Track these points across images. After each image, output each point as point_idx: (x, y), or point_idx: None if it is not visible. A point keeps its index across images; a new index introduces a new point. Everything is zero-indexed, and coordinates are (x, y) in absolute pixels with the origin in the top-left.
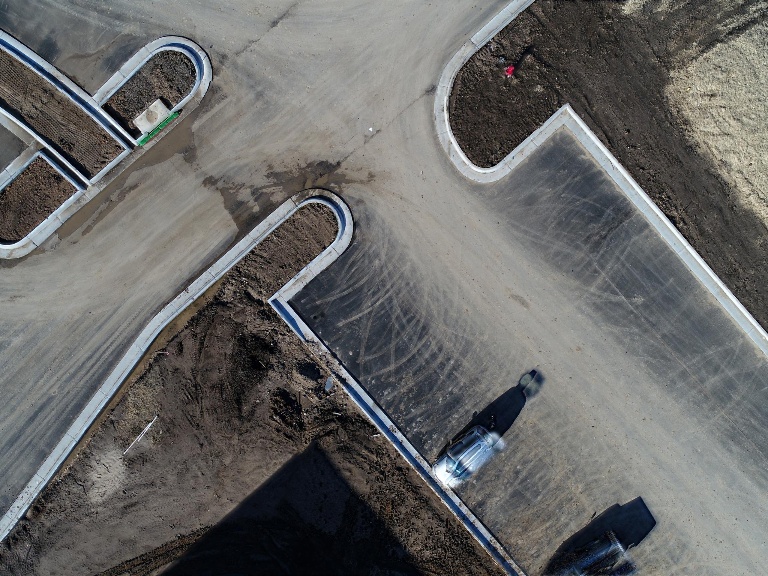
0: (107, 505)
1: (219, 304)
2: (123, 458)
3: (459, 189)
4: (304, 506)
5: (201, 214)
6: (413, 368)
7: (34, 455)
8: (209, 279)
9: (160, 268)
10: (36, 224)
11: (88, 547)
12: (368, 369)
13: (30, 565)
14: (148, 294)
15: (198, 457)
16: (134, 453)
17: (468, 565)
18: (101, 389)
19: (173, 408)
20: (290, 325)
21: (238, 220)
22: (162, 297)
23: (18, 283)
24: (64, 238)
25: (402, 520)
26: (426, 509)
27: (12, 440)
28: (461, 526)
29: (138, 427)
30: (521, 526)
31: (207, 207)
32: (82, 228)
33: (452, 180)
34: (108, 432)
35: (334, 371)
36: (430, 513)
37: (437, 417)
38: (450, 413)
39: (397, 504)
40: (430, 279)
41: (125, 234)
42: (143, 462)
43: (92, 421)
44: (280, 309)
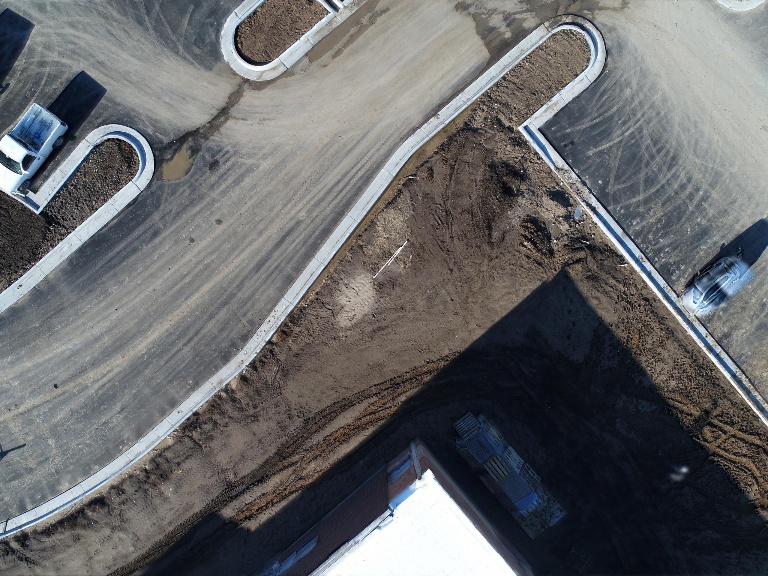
0: (356, 329)
1: (470, 130)
2: (373, 282)
3: (714, 17)
4: (552, 333)
5: (453, 39)
6: (662, 198)
7: (281, 279)
8: (460, 105)
9: (410, 93)
10: (287, 46)
11: (337, 370)
12: (617, 198)
13: (278, 388)
14: (398, 119)
15: (448, 282)
16: (384, 277)
17: (713, 396)
18: (350, 214)
19: (423, 233)
20: (542, 151)
21: (490, 46)
22: (412, 122)
23: (268, 106)
24: (314, 61)
25: (649, 350)
26: (672, 340)
27: (259, 264)
28: (706, 358)
29: (388, 251)
30: (766, 358)
31: (459, 32)
32: (333, 51)
33: (707, 8)
34: (357, 256)
35: (584, 199)
36: (676, 344)
37: (685, 248)
38: (698, 244)
39: (643, 334)
40: (681, 109)
41: (376, 58)
42: (393, 286)
43: (341, 245)
44: (531, 136)
